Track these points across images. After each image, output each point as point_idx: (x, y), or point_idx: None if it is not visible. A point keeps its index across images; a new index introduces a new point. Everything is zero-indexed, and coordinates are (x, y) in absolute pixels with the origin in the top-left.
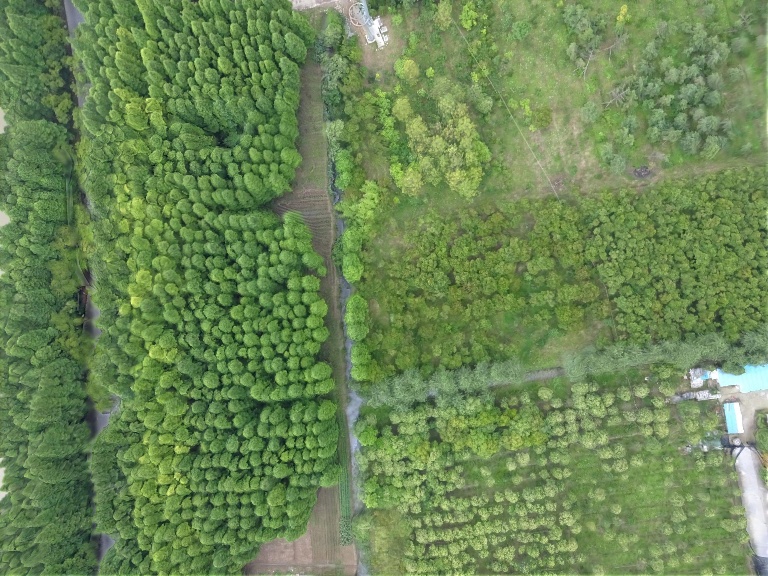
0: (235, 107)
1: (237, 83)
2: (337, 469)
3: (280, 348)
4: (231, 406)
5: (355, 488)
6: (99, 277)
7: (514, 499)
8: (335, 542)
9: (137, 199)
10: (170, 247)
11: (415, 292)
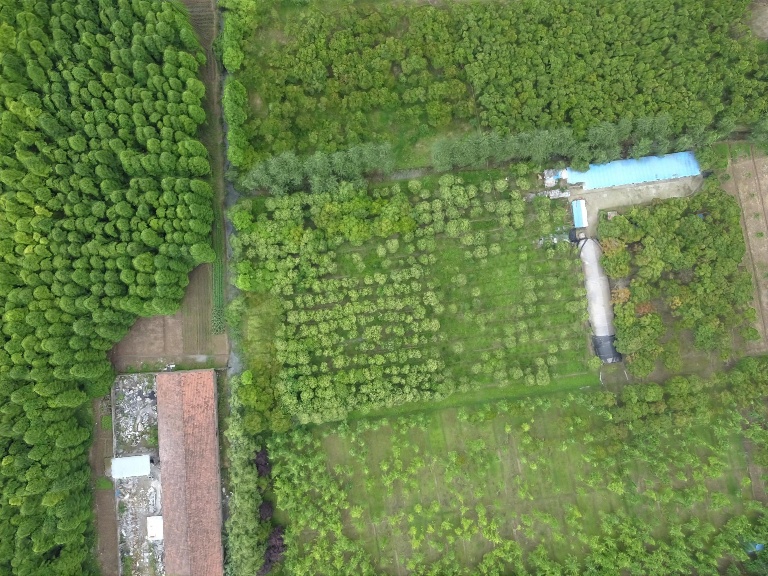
0: None
1: None
2: (210, 248)
3: (153, 115)
4: (98, 168)
5: (229, 280)
6: None
7: (382, 279)
8: (207, 332)
9: None
10: (37, 3)
11: (294, 83)
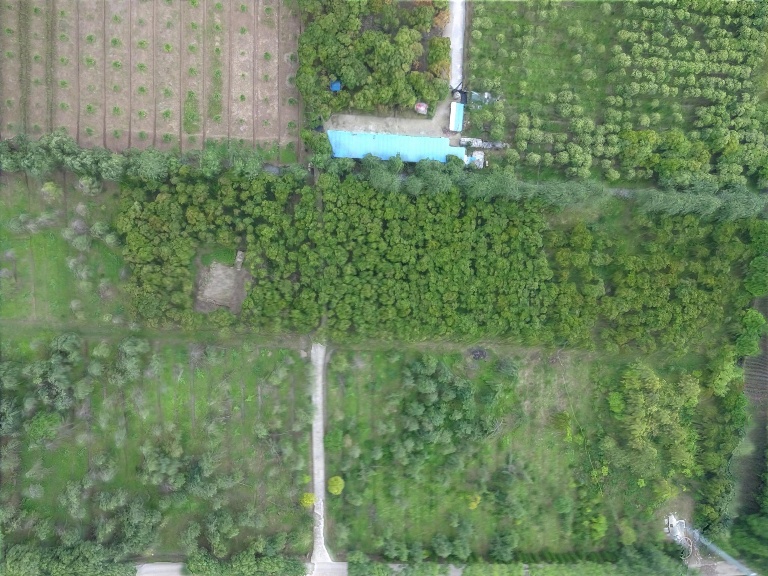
0: None
1: None
2: None
3: None
4: None
5: None
6: None
7: (666, 87)
8: None
9: None
10: None
11: (704, 289)
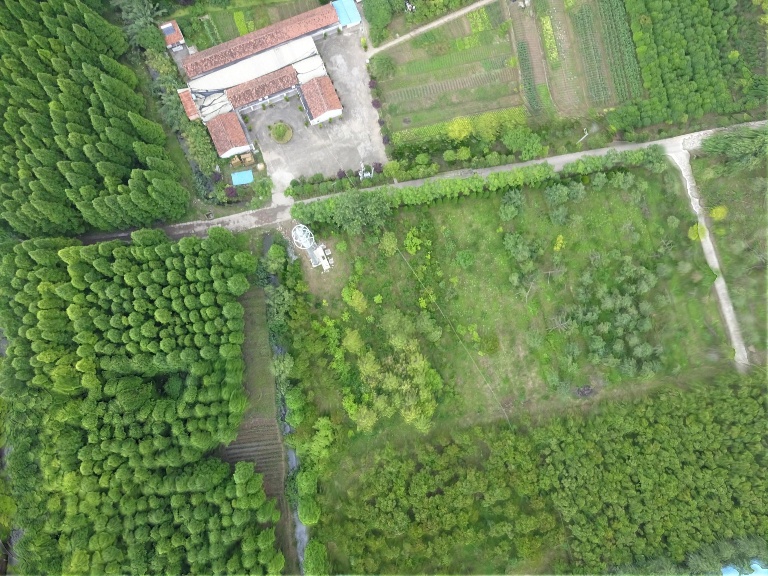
0: (178, 359)
1: (179, 331)
2: None
3: None
4: None
5: None
6: (25, 556)
7: None
8: None
9: (69, 471)
10: (109, 522)
11: (375, 531)
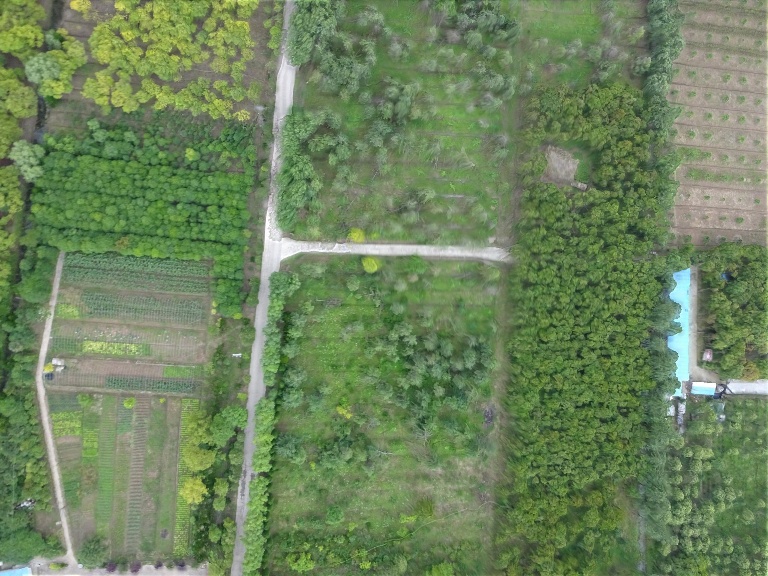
0: None
1: None
2: None
3: None
4: None
5: None
6: None
7: None
8: None
9: None
10: None
11: None
